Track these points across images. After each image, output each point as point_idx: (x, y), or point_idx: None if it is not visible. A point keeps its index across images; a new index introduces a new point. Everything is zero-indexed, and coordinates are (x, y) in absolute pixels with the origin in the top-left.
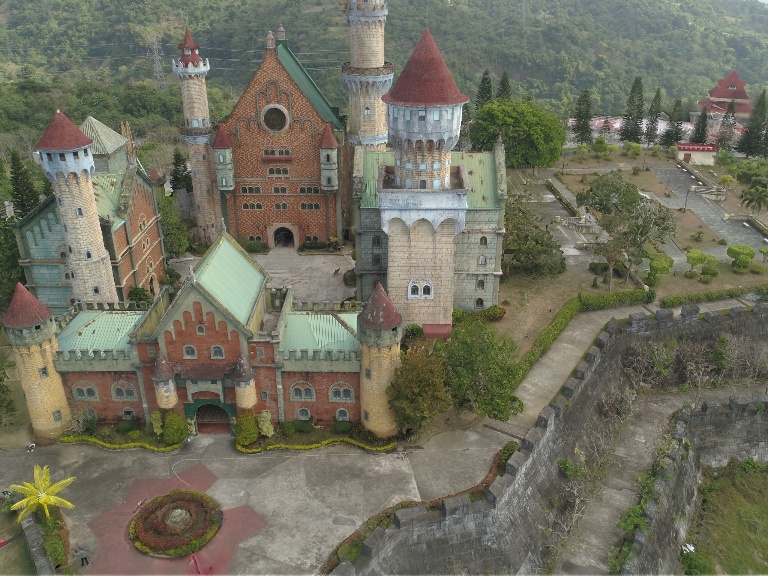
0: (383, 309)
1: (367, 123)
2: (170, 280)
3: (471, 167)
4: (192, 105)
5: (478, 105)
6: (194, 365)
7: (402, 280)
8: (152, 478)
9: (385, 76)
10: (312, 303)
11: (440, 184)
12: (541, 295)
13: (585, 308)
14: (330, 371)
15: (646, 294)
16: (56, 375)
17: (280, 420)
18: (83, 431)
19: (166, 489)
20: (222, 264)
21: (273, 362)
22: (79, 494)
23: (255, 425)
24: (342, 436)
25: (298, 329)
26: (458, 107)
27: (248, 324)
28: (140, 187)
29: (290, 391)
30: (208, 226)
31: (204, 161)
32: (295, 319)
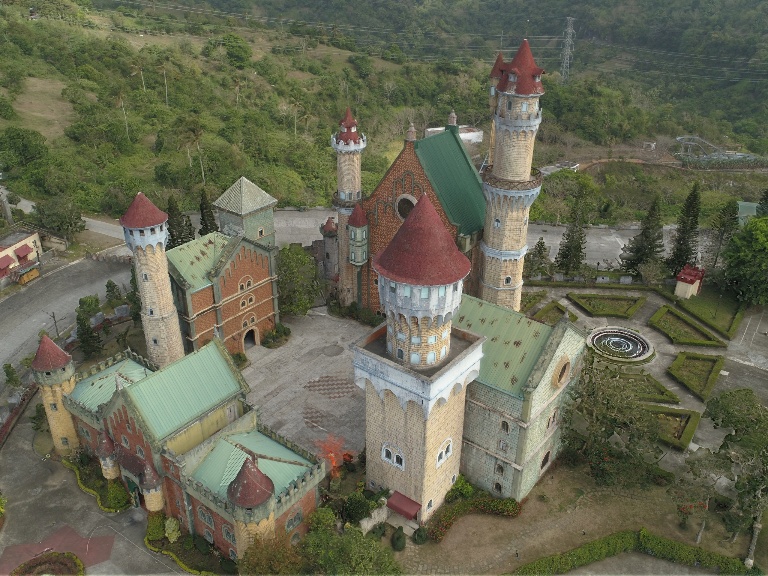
0: (243, 485)
1: (496, 235)
2: (275, 335)
3: (521, 336)
4: (342, 178)
5: (760, 212)
6: (128, 453)
7: (377, 439)
8: (75, 530)
9: (519, 191)
10: (271, 430)
11: (419, 359)
12: (599, 506)
13: (642, 549)
14: (217, 513)
15: (744, 571)
16: (65, 411)
17: (189, 530)
18: (80, 460)
19: (72, 547)
20: (184, 371)
21: (180, 480)
22: (28, 517)
23: (163, 526)
24: (226, 574)
25: (219, 457)
26: (440, 287)
27: (163, 439)
28: (250, 252)
29: (198, 510)
30: (342, 290)
31: (347, 231)
32: (224, 446)
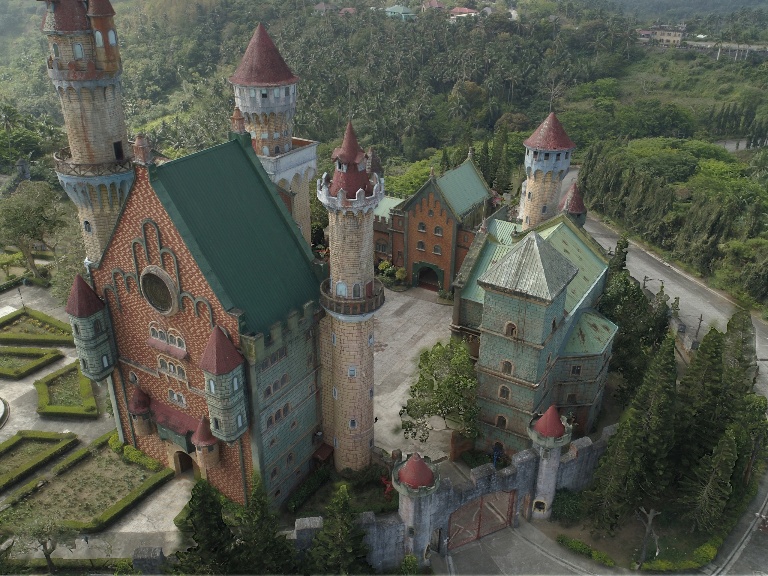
0: None
1: None
2: None
3: None
4: None
5: None
6: None
7: None
8: None
9: None
10: (380, 216)
11: None
12: None
13: None
14: None
15: None
16: None
17: None
18: None
19: None
20: None
21: None
22: None
23: None
24: None
25: None
26: None
27: None
28: None
29: None
30: None
31: None
32: None
